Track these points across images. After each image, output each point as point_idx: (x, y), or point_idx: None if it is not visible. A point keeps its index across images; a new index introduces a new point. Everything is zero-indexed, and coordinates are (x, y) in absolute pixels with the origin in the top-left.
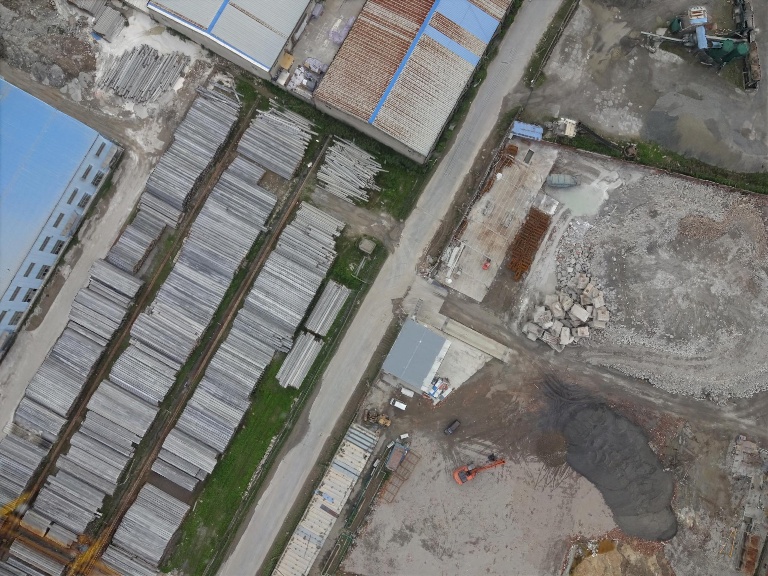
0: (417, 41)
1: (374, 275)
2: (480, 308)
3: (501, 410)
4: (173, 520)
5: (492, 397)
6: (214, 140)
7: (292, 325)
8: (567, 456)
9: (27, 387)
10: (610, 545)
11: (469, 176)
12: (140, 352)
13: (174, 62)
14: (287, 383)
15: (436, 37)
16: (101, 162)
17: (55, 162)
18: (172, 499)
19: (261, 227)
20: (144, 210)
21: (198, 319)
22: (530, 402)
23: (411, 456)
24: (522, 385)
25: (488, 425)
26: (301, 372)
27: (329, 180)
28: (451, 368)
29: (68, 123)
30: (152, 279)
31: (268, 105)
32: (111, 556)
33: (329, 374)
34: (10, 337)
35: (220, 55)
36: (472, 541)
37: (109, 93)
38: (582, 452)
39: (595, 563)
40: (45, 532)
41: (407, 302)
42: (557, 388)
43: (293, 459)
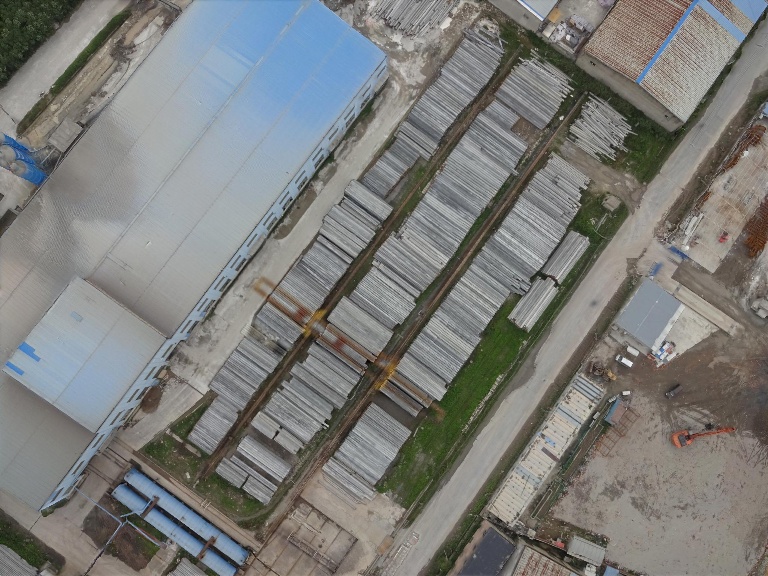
0: (690, 11)
1: (614, 232)
2: (712, 279)
3: (722, 381)
4: (395, 442)
5: (714, 367)
6: (479, 80)
7: (534, 268)
8: None
9: (273, 292)
10: None
11: (714, 150)
12: (382, 274)
13: (445, 2)
14: (524, 324)
15: (708, 9)
16: (374, 85)
17: (343, 76)
18: (396, 421)
19: (512, 170)
20: (401, 138)
21: (443, 250)
22: (751, 378)
23: (630, 414)
24: (745, 360)
25: (708, 394)
26: (536, 315)
27: (581, 134)
28: (677, 333)
29: (360, 41)
30: (400, 206)
31: (529, 55)
32: (332, 468)
33: (559, 322)
34: None
35: (489, 1)
36: (681, 506)
37: (379, 23)
38: None
39: None
40: (274, 435)
41: (642, 263)
42: None
43: (515, 400)
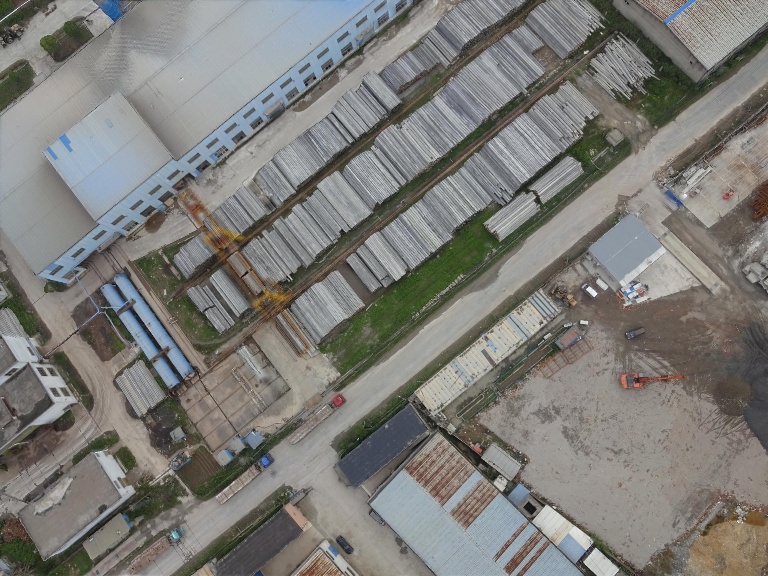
0: None
1: (611, 166)
2: (705, 233)
3: (691, 337)
4: (347, 310)
5: (686, 321)
6: (511, 2)
7: (519, 181)
8: (747, 409)
9: (277, 152)
10: (761, 520)
11: (740, 108)
12: (377, 159)
13: None
14: (495, 229)
15: None
16: None
17: None
18: (353, 292)
19: (523, 89)
20: (427, 44)
21: (437, 147)
22: (725, 342)
23: (583, 344)
24: (723, 322)
25: (672, 346)
26: (510, 225)
27: (600, 69)
28: (654, 278)
29: None
30: (410, 103)
31: None
32: (285, 318)
33: (533, 240)
34: (280, 109)
35: None
36: (614, 449)
37: None
38: (767, 409)
39: (738, 529)
40: (244, 274)
41: (633, 202)
42: (760, 339)
43: (471, 302)
